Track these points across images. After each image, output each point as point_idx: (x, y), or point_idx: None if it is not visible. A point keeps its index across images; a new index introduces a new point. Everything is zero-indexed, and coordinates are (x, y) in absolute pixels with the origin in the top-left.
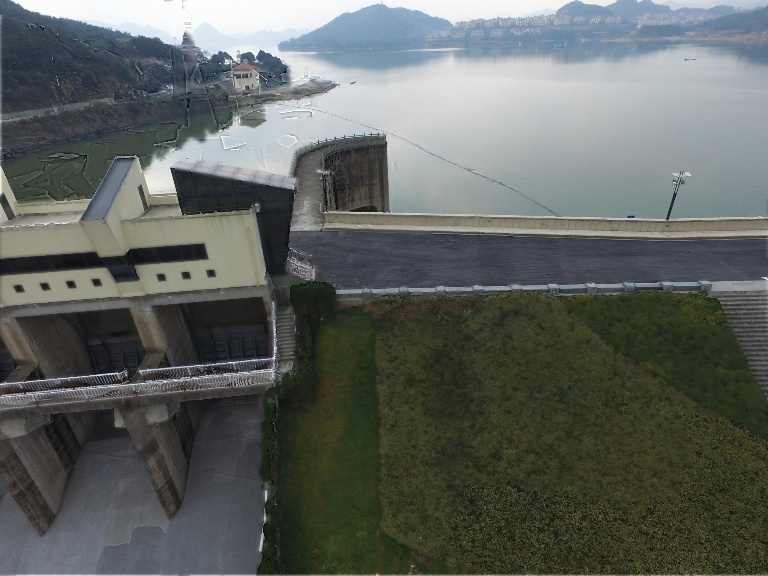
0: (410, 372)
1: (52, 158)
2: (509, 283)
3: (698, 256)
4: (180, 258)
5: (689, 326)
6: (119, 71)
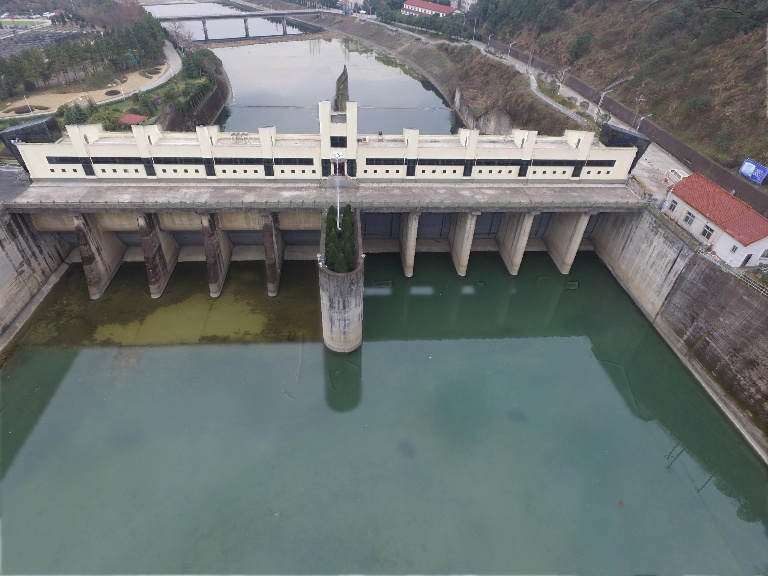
0: None
1: None
2: None
3: None
4: None
5: None
6: None
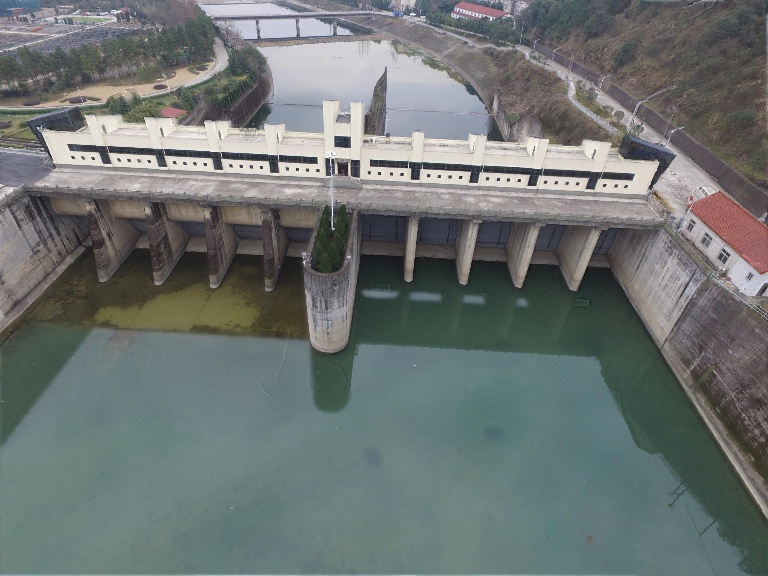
0: None
1: None
2: None
3: None
4: None
5: None
6: None
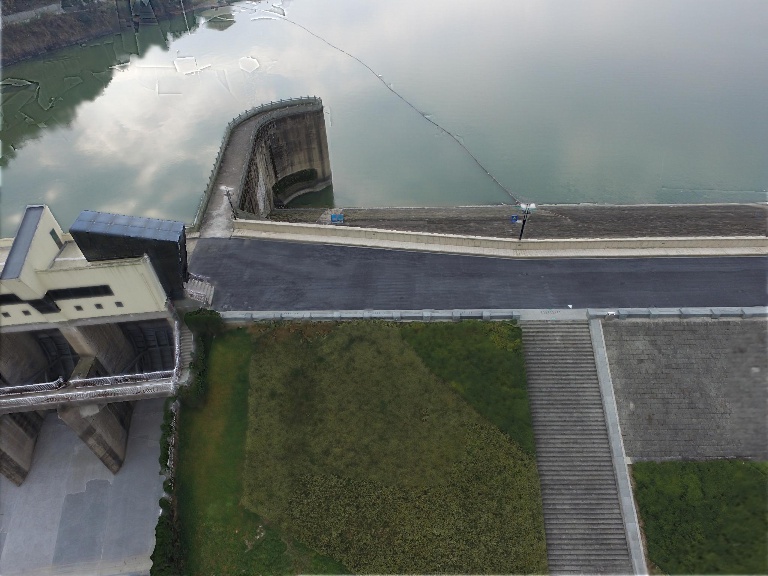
0: (273, 387)
1: (3, 85)
2: (366, 307)
3: (531, 279)
4: (91, 295)
5: (492, 352)
6: None
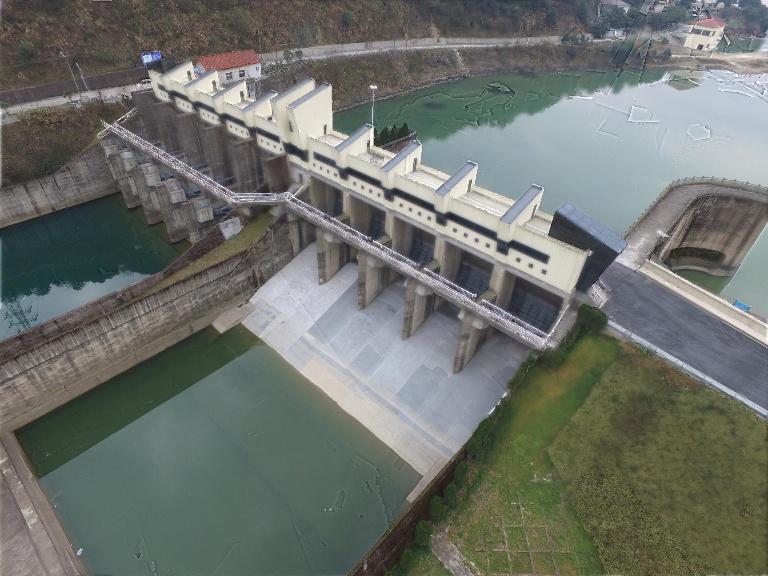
0: (618, 394)
1: (492, 87)
2: (741, 392)
3: None
4: (533, 256)
5: None
6: (581, 11)
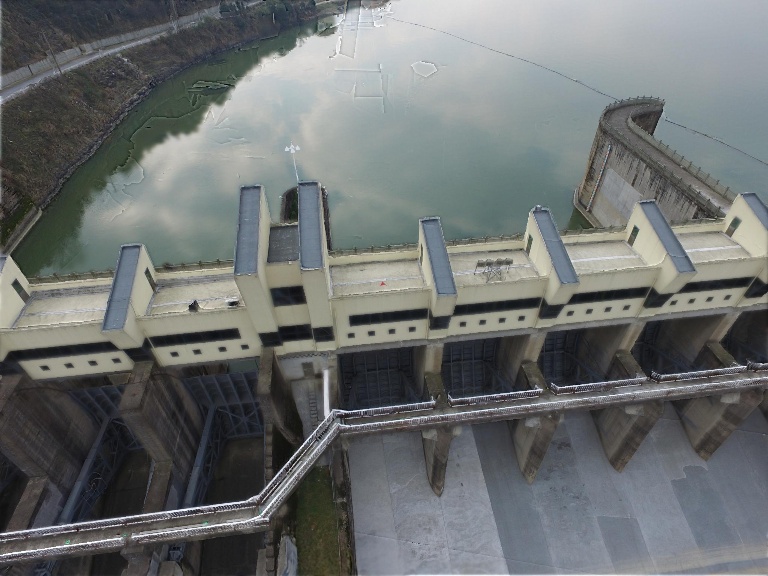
0: None
1: (200, 88)
2: None
3: None
4: None
5: None
6: None
